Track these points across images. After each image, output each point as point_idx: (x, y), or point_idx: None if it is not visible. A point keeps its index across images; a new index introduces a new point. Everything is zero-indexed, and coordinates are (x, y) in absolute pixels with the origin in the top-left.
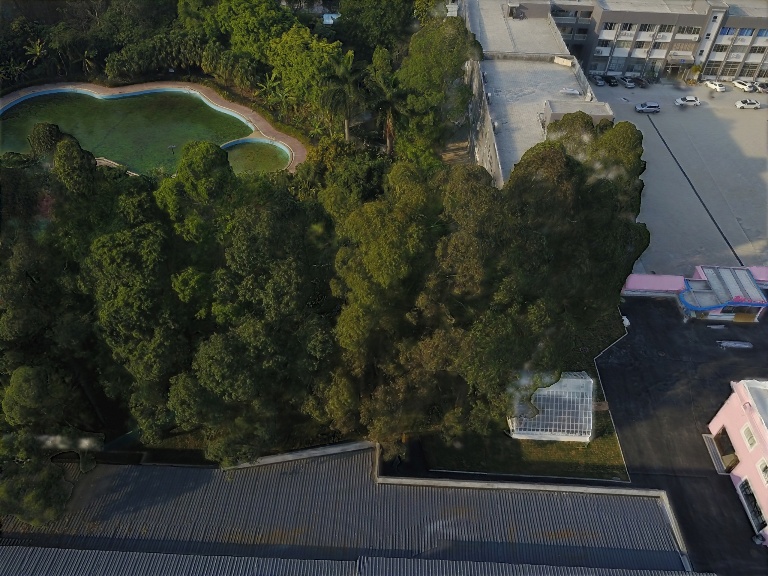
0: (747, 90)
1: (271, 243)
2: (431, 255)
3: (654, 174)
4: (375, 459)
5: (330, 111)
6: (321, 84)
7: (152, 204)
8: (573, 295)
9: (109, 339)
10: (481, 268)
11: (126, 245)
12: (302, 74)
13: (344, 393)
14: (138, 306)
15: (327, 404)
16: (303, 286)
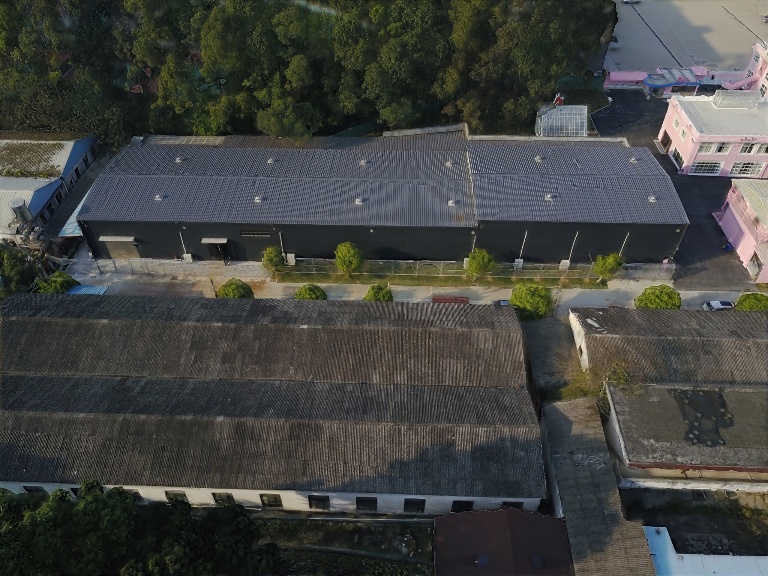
0: None
1: None
2: None
3: (634, 35)
4: (465, 133)
5: None
6: None
7: None
8: (573, 26)
9: (336, 44)
10: None
11: None
12: None
13: (454, 74)
14: (354, 22)
15: (445, 83)
16: (434, 14)
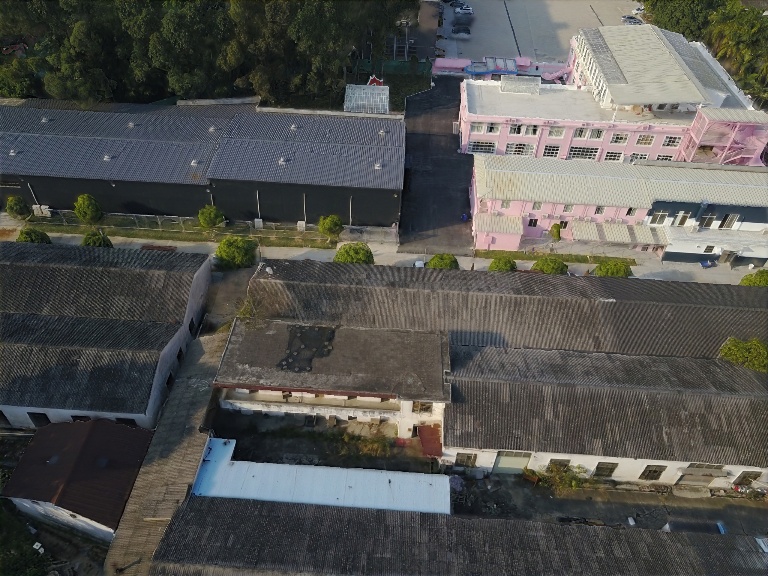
0: None
1: None
2: None
3: (491, 28)
4: None
5: None
6: None
7: None
8: (353, 7)
9: (121, 13)
10: None
11: None
12: None
13: (235, 47)
14: None
15: (228, 56)
16: None
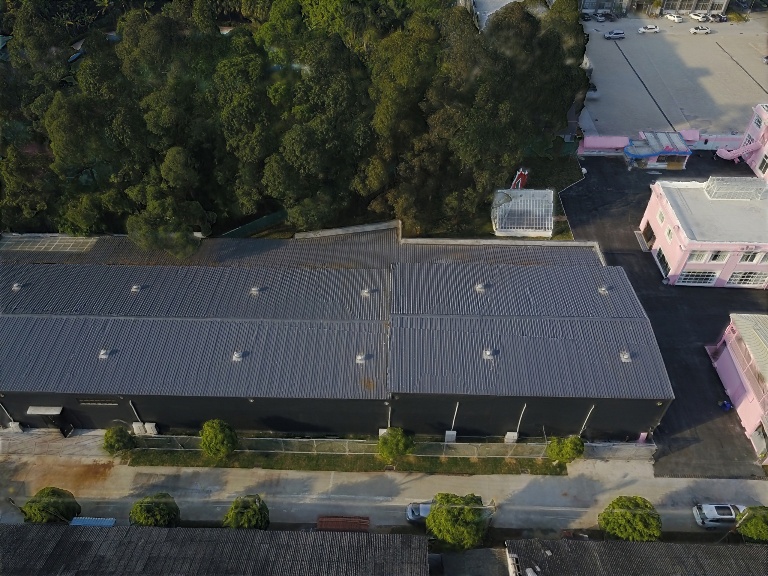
0: (701, 20)
1: (330, 63)
2: (433, 65)
3: (616, 81)
4: (399, 232)
5: (352, 30)
6: (345, 10)
7: (252, 43)
8: (530, 104)
9: (226, 132)
10: (465, 67)
11: (238, 65)
12: (327, 9)
13: (379, 168)
14: (247, 105)
15: (367, 178)
16: (351, 93)
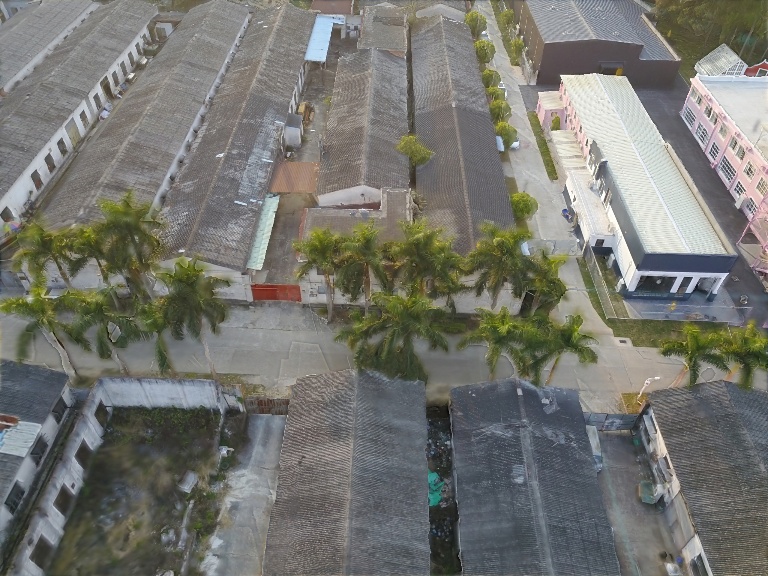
0: None
1: None
2: None
3: None
4: None
5: None
6: None
7: None
8: None
9: None
10: None
11: None
12: None
13: None
14: None
15: None
16: None
